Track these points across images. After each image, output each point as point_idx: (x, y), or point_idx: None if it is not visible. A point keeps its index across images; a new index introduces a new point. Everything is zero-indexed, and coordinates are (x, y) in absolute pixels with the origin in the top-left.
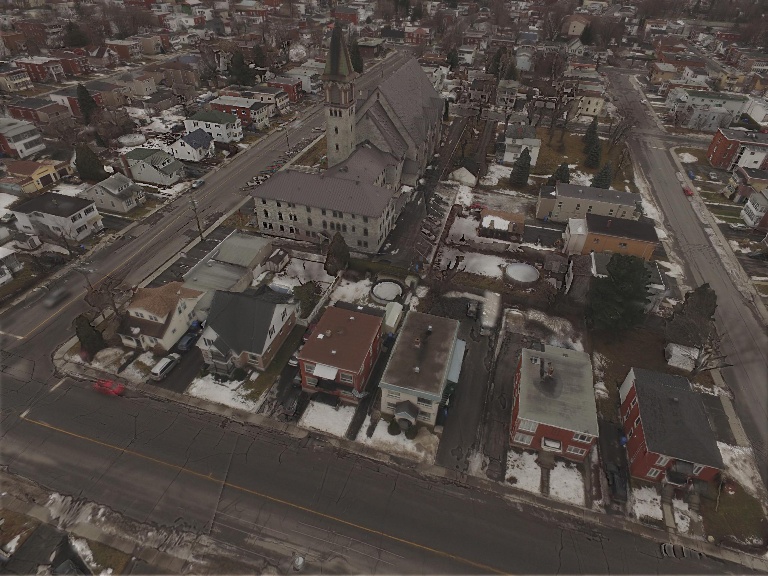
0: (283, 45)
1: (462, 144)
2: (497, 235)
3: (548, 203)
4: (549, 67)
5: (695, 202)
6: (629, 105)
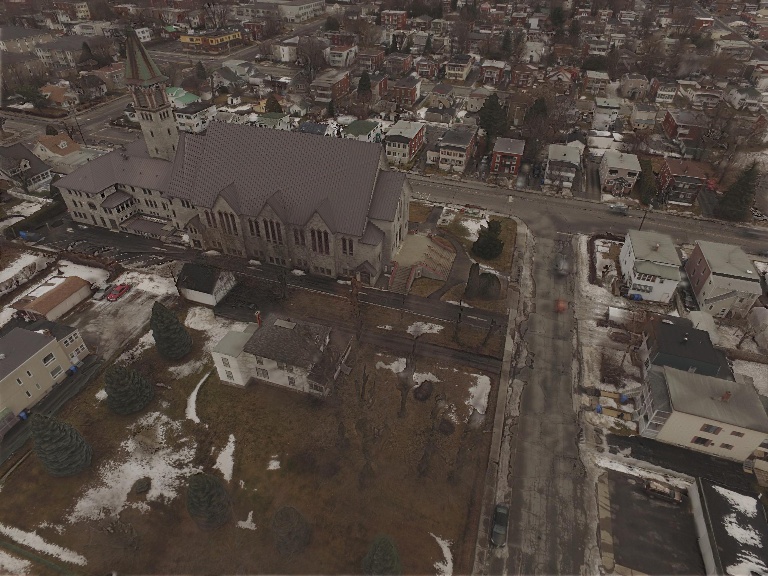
0: None
1: None
2: None
3: None
4: None
5: None
6: None
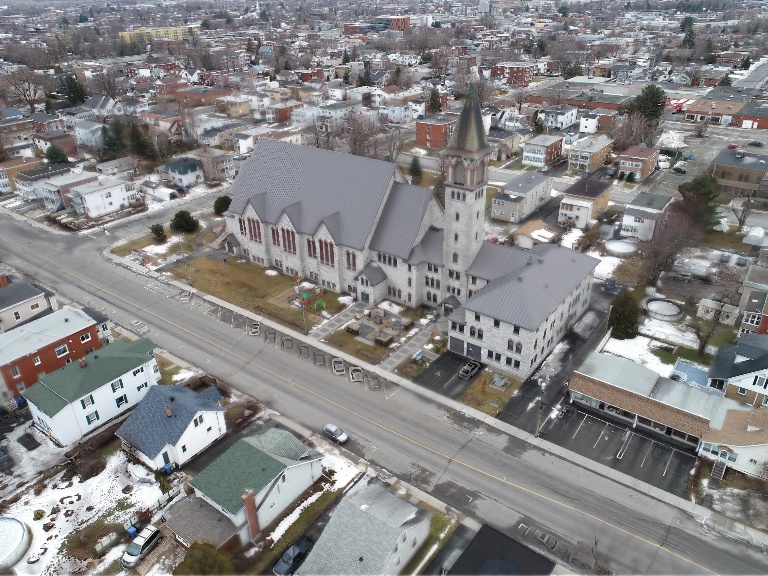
0: None
1: None
2: None
3: (521, 205)
4: None
5: (498, 170)
6: None
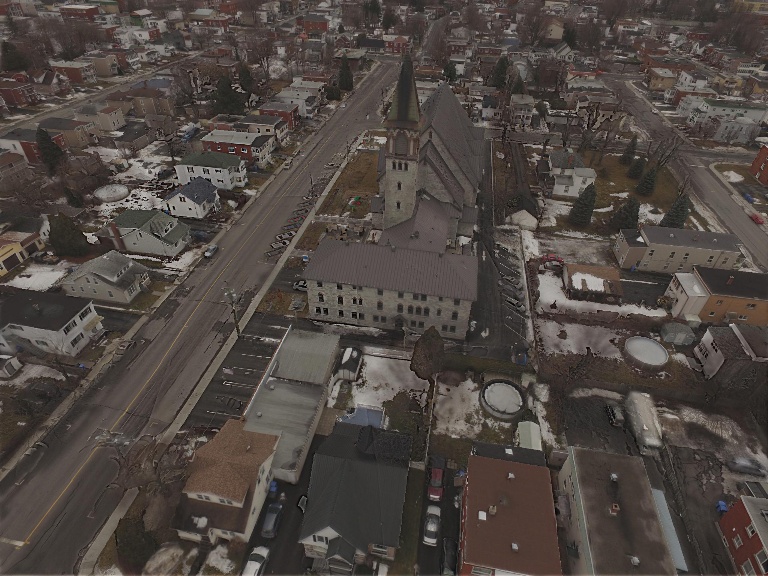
0: (261, 61)
1: (506, 177)
2: (591, 297)
3: (637, 252)
4: (546, 76)
5: None
6: (643, 116)
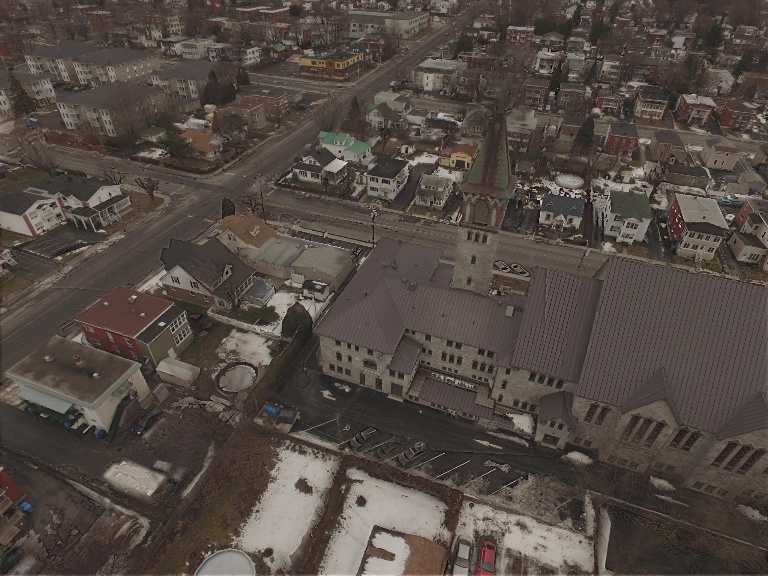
0: None
1: None
2: None
3: None
4: None
5: None
6: None
